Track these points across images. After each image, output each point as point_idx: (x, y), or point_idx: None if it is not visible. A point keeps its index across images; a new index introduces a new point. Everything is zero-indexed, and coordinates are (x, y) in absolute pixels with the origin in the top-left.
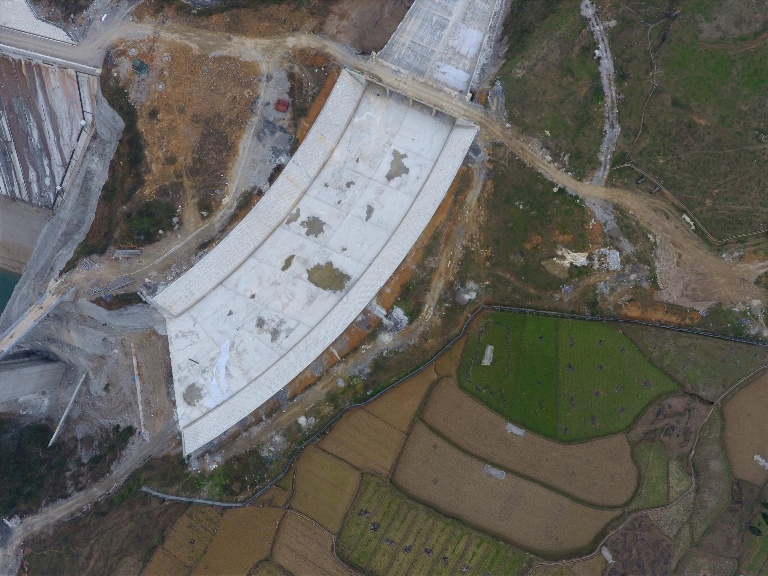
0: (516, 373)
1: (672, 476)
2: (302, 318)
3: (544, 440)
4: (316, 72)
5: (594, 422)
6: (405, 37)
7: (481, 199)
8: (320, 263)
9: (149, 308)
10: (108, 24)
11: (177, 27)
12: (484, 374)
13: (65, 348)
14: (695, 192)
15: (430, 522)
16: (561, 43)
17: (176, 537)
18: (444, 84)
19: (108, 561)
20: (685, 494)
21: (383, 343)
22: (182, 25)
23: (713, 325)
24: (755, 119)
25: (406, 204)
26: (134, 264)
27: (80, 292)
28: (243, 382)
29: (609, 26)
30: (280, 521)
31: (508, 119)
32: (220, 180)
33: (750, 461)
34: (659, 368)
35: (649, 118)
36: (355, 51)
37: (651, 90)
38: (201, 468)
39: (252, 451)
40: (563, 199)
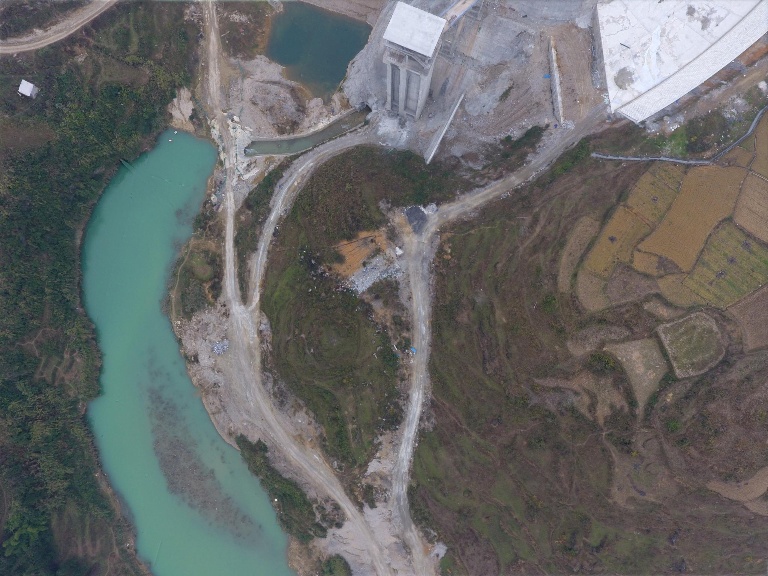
0: None
1: None
2: (732, 8)
3: None
4: None
5: None
6: None
7: None
8: None
9: None
10: None
11: None
12: None
13: (457, 59)
14: None
15: None
16: None
17: (639, 194)
18: None
19: (561, 223)
20: None
21: None
22: None
23: None
24: None
25: None
26: None
27: None
28: (674, 68)
29: None
30: (743, 182)
31: None
32: None
33: None
34: None
35: None
36: None
37: None
38: (660, 130)
39: (716, 111)
40: None
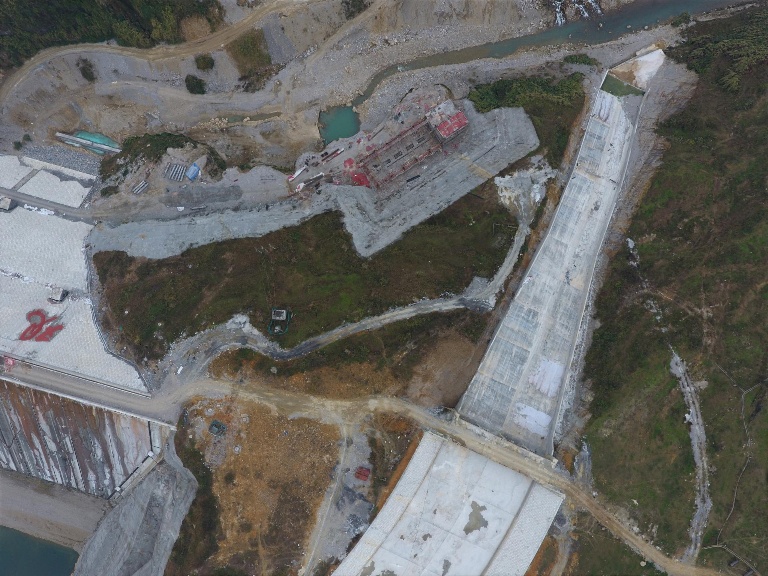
0: None
1: None
2: None
3: None
4: (398, 439)
5: None
6: (485, 374)
7: (566, 574)
8: None
9: None
10: (184, 378)
11: (256, 387)
12: None
13: None
14: None
15: None
16: (649, 402)
17: None
18: (525, 430)
19: None
20: None
21: None
22: (261, 385)
23: None
24: None
25: (484, 559)
26: None
27: None
28: None
29: (700, 388)
30: None
31: (595, 486)
32: (296, 550)
33: None
34: None
35: (742, 495)
36: (438, 411)
37: (744, 463)
38: None
39: None
40: (651, 574)
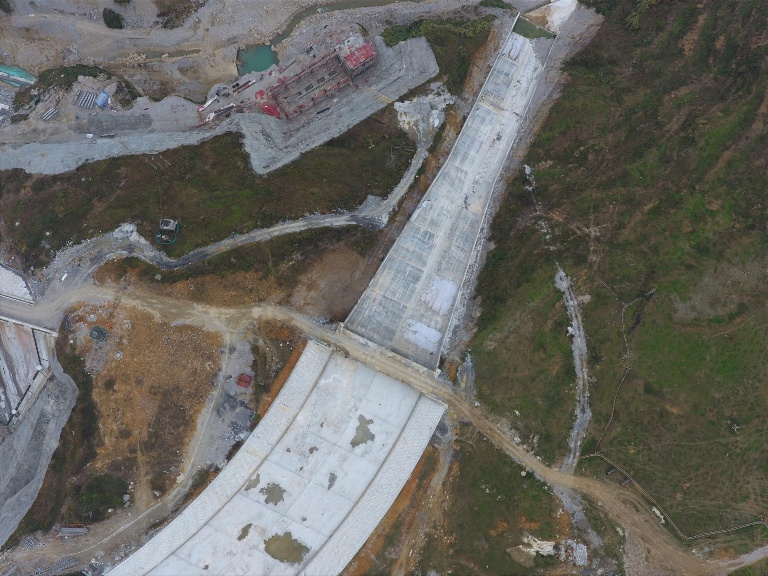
0: None
1: None
2: None
3: None
4: (281, 346)
5: None
6: (377, 291)
7: (446, 483)
8: (278, 533)
9: None
10: (68, 285)
11: (139, 293)
12: None
13: None
14: (666, 485)
15: None
16: (534, 315)
17: None
18: (414, 345)
19: None
20: None
21: None
22: (144, 291)
23: None
24: (728, 407)
25: (370, 473)
26: (80, 543)
27: (22, 570)
28: None
29: (583, 302)
30: None
31: (477, 397)
32: (176, 456)
33: None
34: None
35: (621, 405)
36: (323, 321)
37: (623, 374)
38: None
39: None
40: (531, 484)
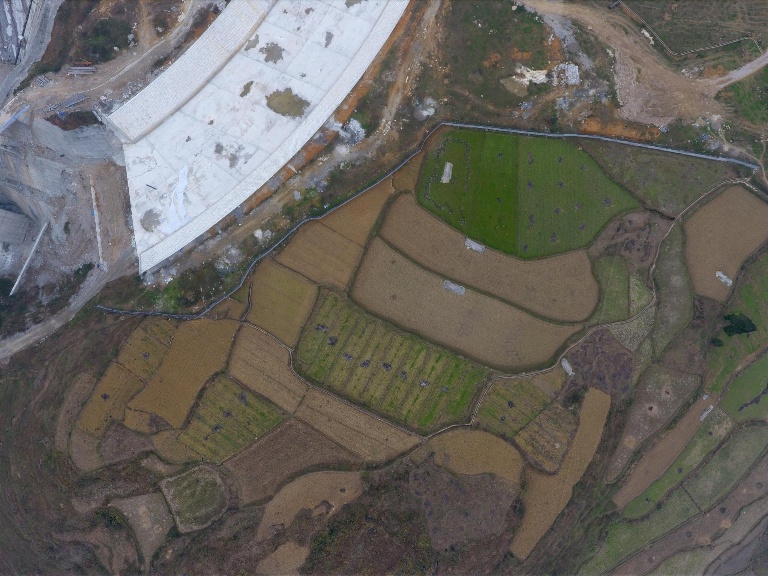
0: (475, 190)
1: (633, 290)
2: (261, 144)
3: (504, 256)
4: None
5: (554, 239)
6: None
7: (439, 16)
8: (279, 89)
9: (106, 131)
10: None
11: None
12: (443, 191)
13: (25, 191)
14: (654, 6)
15: (388, 336)
16: None
17: (130, 350)
18: None
19: (63, 379)
20: (646, 308)
21: (340, 155)
22: None
23: (673, 141)
24: None
25: (366, 30)
26: (89, 82)
27: (35, 111)
28: (201, 208)
29: None
30: (236, 334)
31: None
32: None
33: (712, 278)
34: (619, 185)
35: None
36: None
37: None
38: (156, 282)
39: (207, 263)
40: (522, 17)
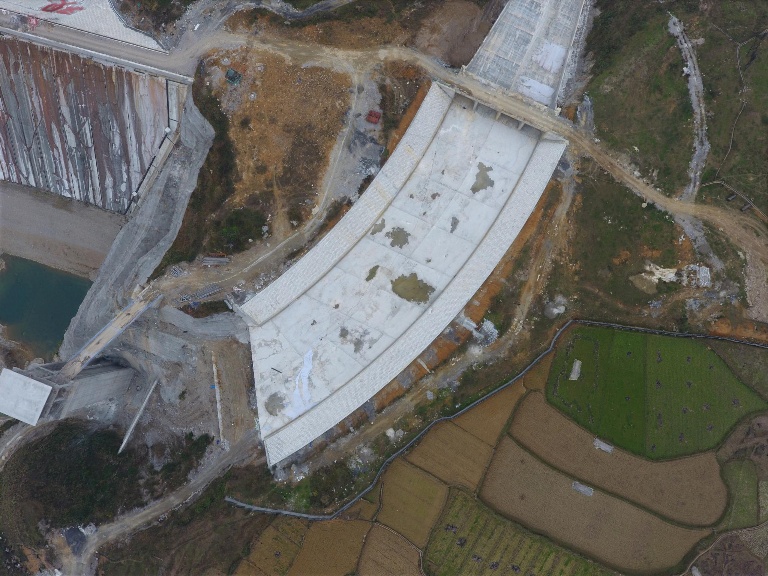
0: (604, 388)
1: (762, 496)
2: (386, 329)
3: (632, 457)
4: (408, 84)
5: (682, 440)
6: (490, 51)
7: (570, 213)
8: (404, 274)
9: (234, 316)
10: (201, 34)
11: (270, 38)
12: (572, 389)
13: (140, 354)
14: None
15: (517, 538)
16: (649, 60)
17: (262, 549)
18: (529, 98)
19: (190, 572)
20: None
21: (473, 356)
22: (275, 36)
23: None
24: None
25: (491, 217)
26: (223, 272)
27: (167, 299)
28: (326, 392)
29: (697, 44)
30: (367, 534)
31: (597, 134)
32: (310, 190)
33: None
34: (748, 386)
35: (739, 136)
36: (445, 64)
37: (740, 108)
38: (287, 479)
39: (340, 463)
40: (652, 215)
